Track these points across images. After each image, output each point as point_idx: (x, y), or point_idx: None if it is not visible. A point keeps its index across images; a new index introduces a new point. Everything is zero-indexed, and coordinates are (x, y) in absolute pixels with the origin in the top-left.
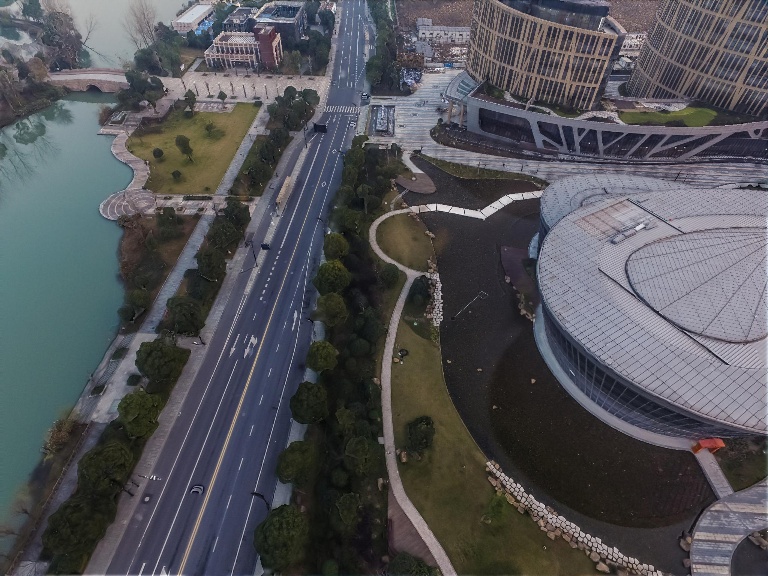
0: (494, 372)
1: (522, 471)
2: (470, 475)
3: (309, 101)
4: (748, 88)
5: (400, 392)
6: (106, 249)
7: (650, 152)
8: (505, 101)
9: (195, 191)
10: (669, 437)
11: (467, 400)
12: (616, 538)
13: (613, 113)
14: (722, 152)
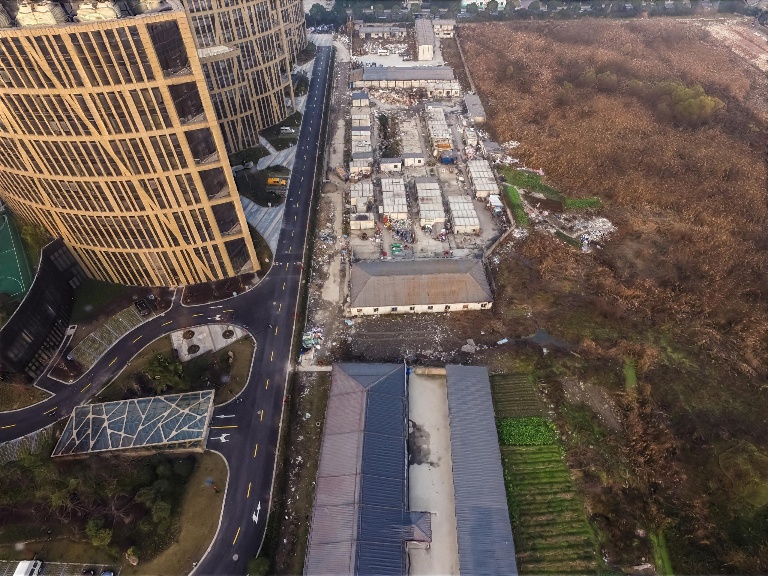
0: None
1: None
2: None
3: None
4: None
5: None
6: None
7: None
8: None
9: None
10: None
11: None
12: None
13: None
14: None
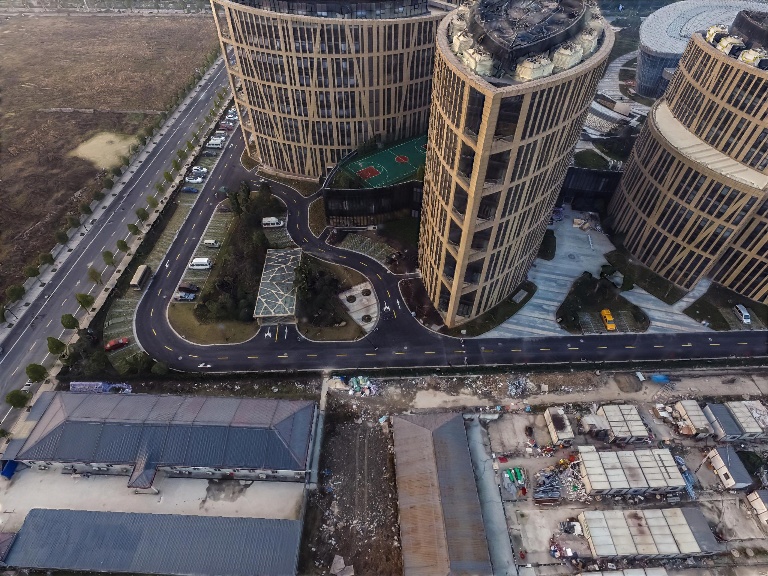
0: None
1: None
2: None
3: None
4: None
5: None
6: None
7: None
8: None
9: None
10: None
11: None
12: None
13: None
14: None
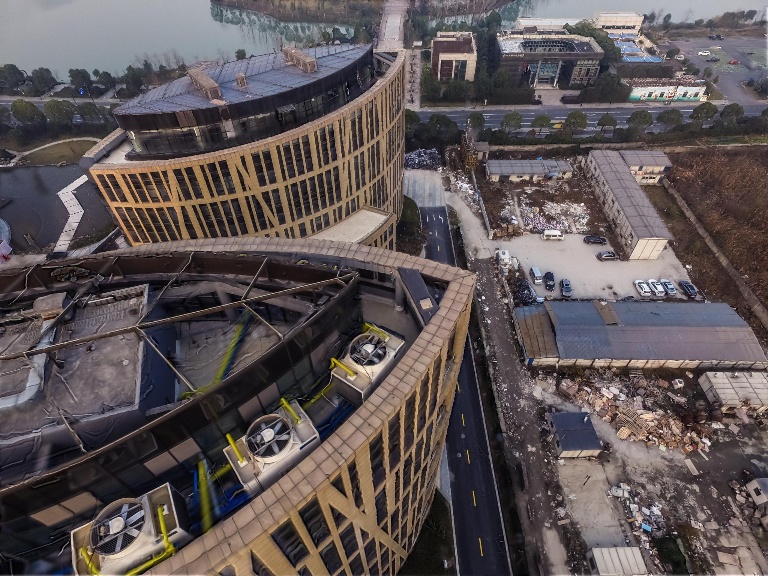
0: None
1: None
2: None
3: None
4: None
5: None
6: (155, 68)
7: None
8: None
9: None
10: None
11: None
12: None
13: None
14: None
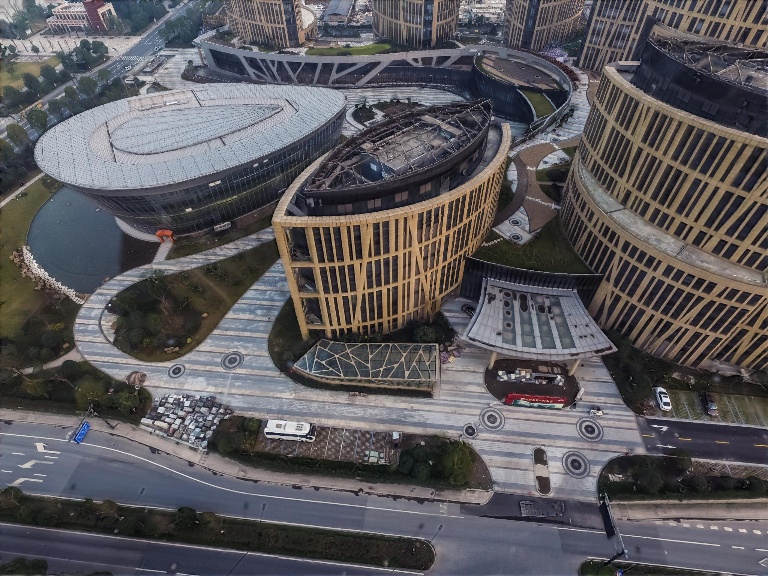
0: (77, 206)
1: (43, 251)
2: (4, 250)
3: (96, 50)
4: (407, 25)
5: (1, 213)
6: None
7: (330, 79)
8: (228, 43)
9: None
10: (153, 235)
11: (44, 219)
12: (67, 279)
13: (305, 49)
14: (398, 79)
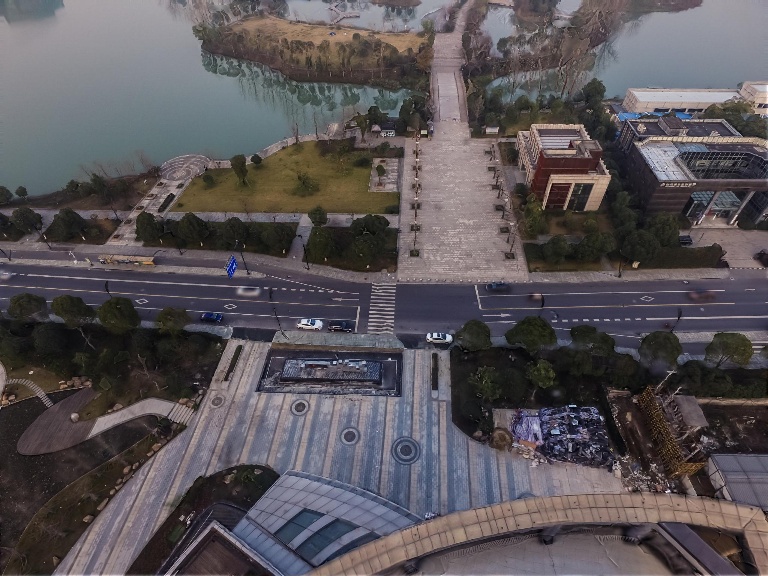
0: None
1: None
2: None
3: (350, 249)
4: None
5: None
6: (115, 172)
7: None
8: None
9: (182, 199)
10: None
11: None
12: None
13: None
14: None
